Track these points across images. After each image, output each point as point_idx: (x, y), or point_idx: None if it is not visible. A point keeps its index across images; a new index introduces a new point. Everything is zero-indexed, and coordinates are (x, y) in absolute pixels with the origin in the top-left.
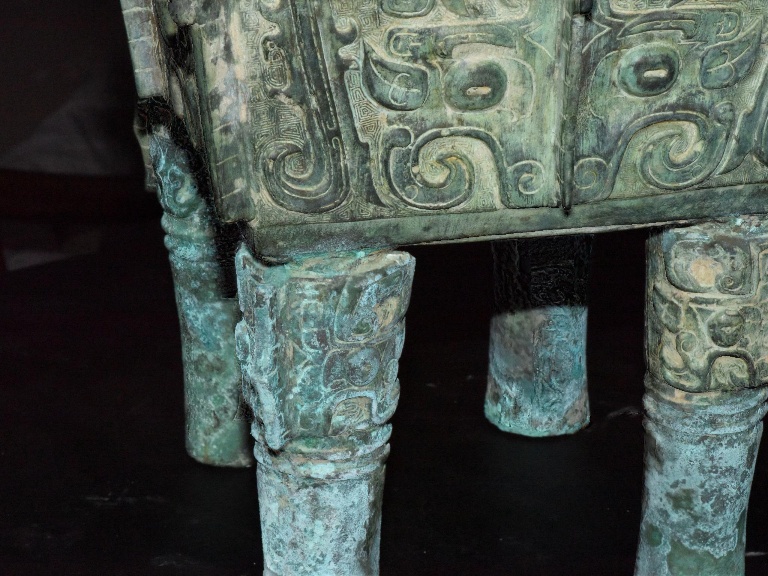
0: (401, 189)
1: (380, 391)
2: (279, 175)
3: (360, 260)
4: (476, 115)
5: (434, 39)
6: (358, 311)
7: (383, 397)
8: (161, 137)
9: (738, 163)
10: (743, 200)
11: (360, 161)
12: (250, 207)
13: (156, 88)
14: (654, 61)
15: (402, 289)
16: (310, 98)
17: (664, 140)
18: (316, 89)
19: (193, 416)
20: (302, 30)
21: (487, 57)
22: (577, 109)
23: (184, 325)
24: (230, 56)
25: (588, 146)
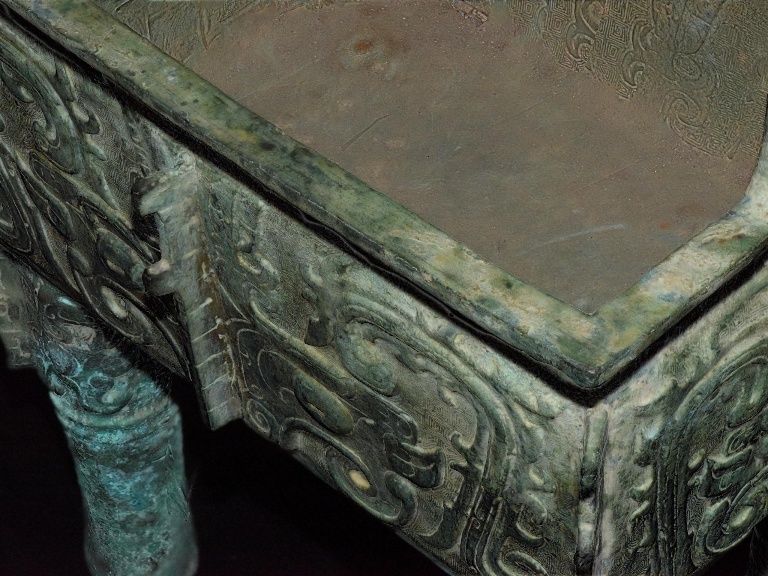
0: (712, 547)
1: None
2: None
3: None
4: None
5: (765, 421)
6: None
7: None
8: (75, 349)
9: None
10: None
11: (685, 550)
12: None
13: (231, 416)
14: None
15: None
16: (658, 533)
17: None
18: (668, 526)
19: (120, 565)
20: (667, 491)
21: None
22: None
23: (103, 493)
24: (600, 547)
25: None
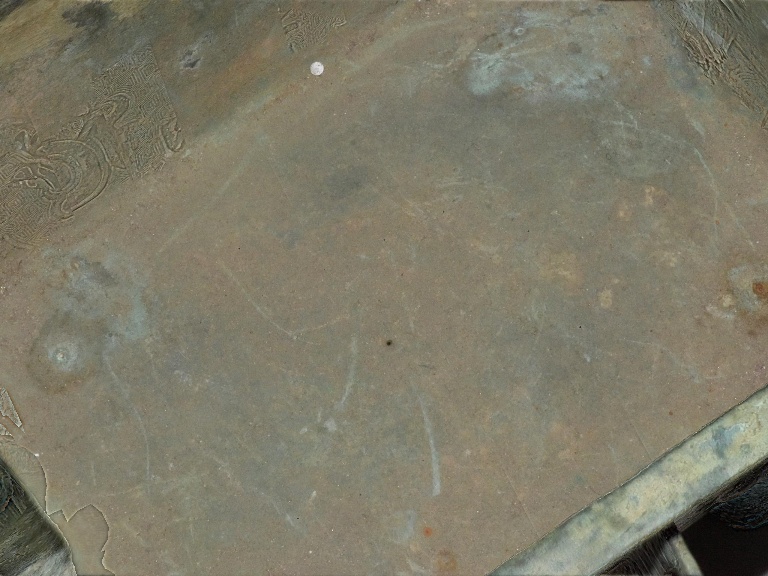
0: None
1: None
2: None
3: None
4: None
5: None
6: None
7: None
8: None
9: None
10: None
11: None
12: None
13: None
14: None
15: None
16: None
17: None
18: None
19: None
20: None
21: None
22: None
23: None
24: None
25: None
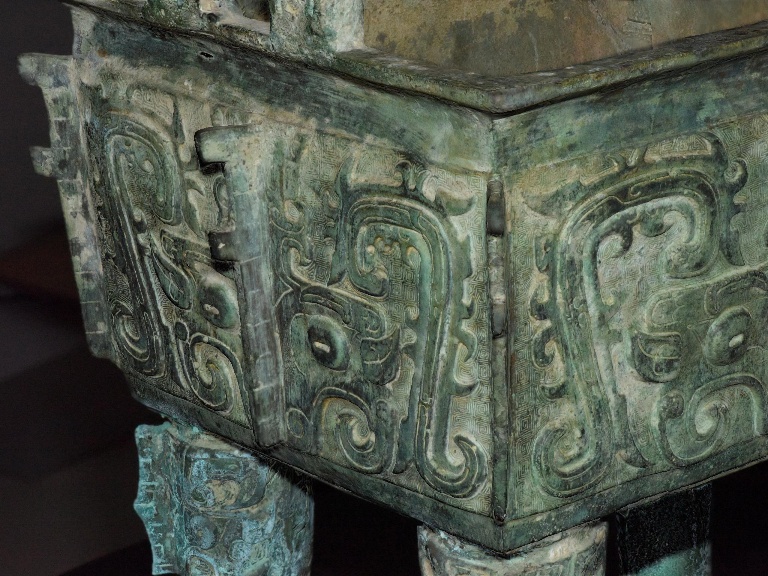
0: None
1: (226, 563)
2: (119, 330)
3: (200, 435)
4: (226, 333)
5: None
6: (192, 479)
7: (232, 570)
8: None
9: (402, 467)
10: (429, 511)
11: None
12: (112, 350)
13: None
14: (319, 334)
15: (246, 479)
16: None
17: (345, 417)
18: None
19: None
20: None
21: (221, 281)
22: (250, 352)
23: None
24: (89, 215)
25: (295, 397)
